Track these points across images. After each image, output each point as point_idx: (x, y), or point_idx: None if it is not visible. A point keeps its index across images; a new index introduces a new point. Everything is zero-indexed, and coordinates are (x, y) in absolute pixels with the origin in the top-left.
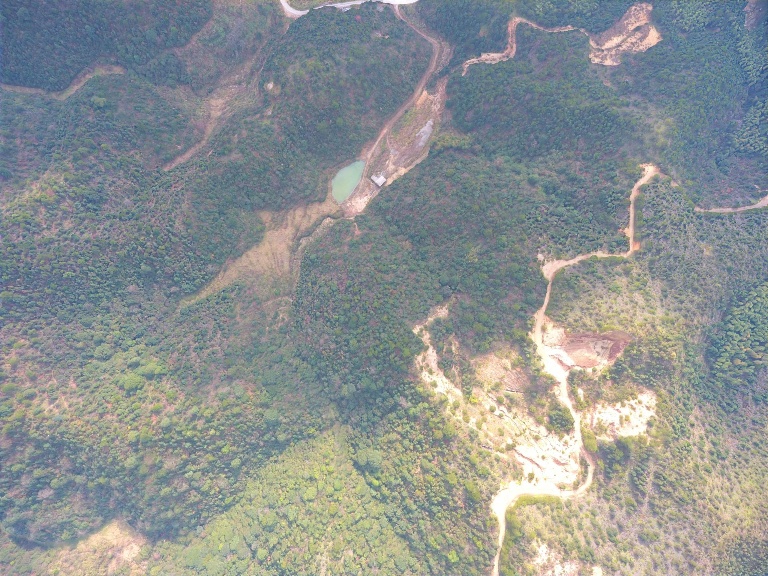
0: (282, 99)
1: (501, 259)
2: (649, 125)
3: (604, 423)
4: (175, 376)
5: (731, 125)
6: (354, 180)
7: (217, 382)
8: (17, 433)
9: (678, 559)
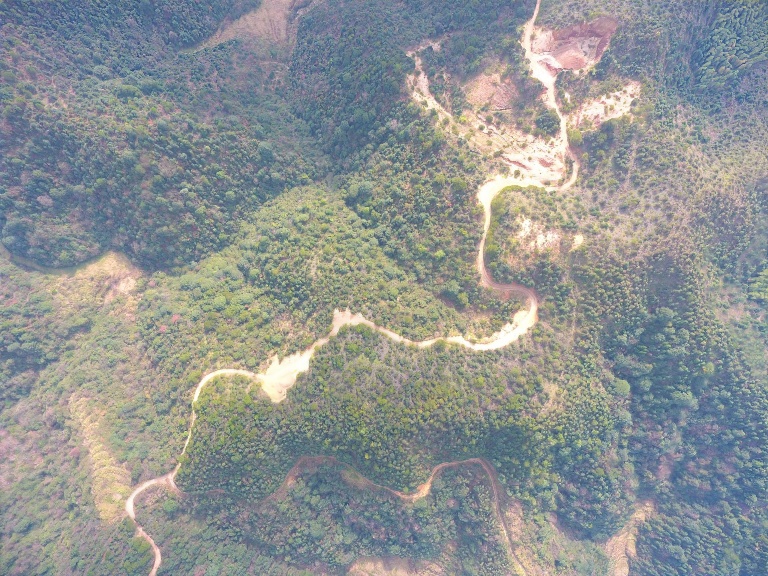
0: None
1: None
2: None
3: (589, 118)
4: (172, 92)
5: None
6: None
7: (213, 110)
8: (17, 121)
9: (657, 215)
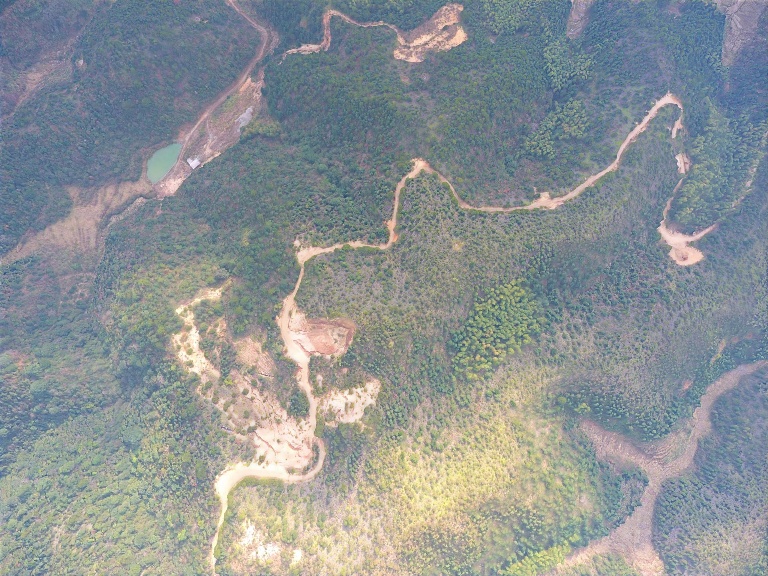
0: (87, 75)
1: (265, 244)
2: (422, 120)
3: (334, 410)
4: None
5: (524, 128)
6: (170, 162)
7: None
8: None
9: (367, 546)
